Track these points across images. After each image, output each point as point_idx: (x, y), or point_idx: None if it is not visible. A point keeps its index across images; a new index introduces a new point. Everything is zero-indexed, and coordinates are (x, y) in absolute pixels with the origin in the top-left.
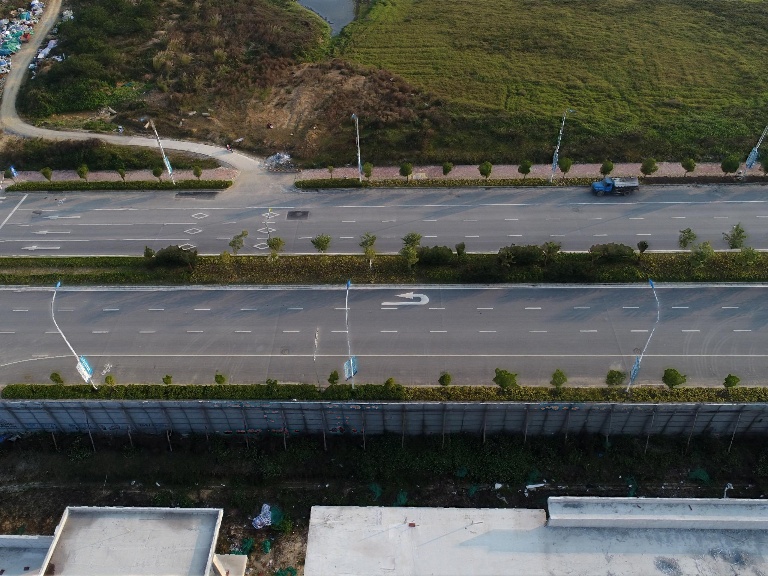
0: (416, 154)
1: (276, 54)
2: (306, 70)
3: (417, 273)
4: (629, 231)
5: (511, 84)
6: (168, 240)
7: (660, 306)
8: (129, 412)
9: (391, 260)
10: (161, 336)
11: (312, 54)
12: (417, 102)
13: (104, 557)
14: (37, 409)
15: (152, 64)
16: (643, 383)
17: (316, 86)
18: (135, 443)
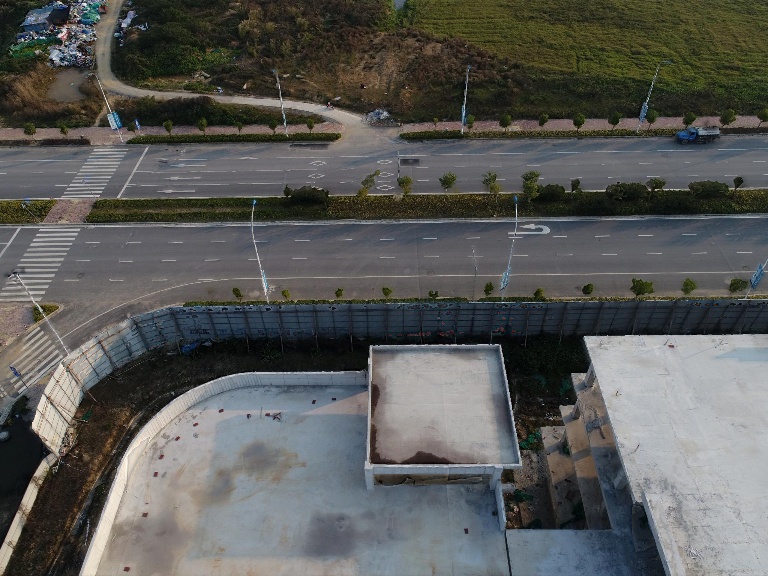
0: (507, 110)
1: (353, 23)
2: (384, 38)
3: (535, 208)
4: (717, 172)
5: (578, 50)
6: (295, 183)
7: (759, 232)
8: (317, 316)
9: (508, 198)
10: (313, 262)
11: (384, 24)
12: (498, 65)
13: (416, 379)
14: (237, 313)
15: (237, 32)
16: (757, 293)
17: (397, 52)
18: (320, 345)
